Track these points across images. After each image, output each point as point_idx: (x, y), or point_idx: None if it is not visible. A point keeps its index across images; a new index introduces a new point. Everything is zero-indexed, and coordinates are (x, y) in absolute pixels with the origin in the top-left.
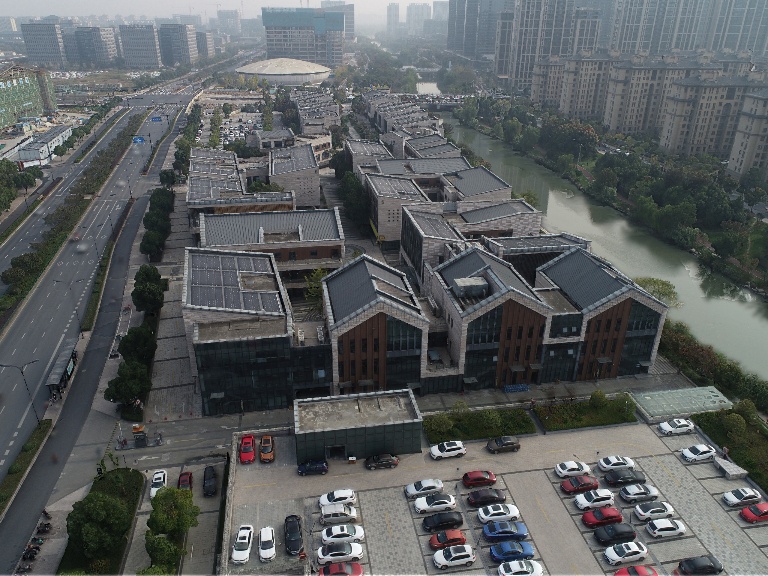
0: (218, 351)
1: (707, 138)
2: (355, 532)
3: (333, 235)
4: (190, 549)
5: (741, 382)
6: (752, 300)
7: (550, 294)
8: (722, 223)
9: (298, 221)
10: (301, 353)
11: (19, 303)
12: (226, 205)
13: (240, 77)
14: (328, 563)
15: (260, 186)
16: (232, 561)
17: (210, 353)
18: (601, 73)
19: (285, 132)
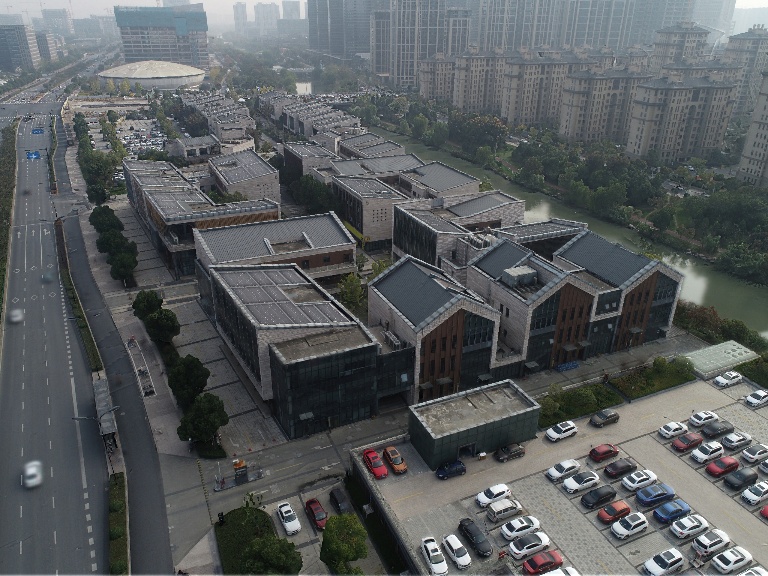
0: (308, 369)
1: (600, 125)
2: (532, 522)
3: (342, 239)
4: None
5: (746, 334)
6: (693, 265)
7: (580, 275)
8: (648, 200)
9: (299, 228)
10: (386, 360)
11: None
12: (208, 218)
13: (109, 82)
14: (524, 557)
15: (218, 196)
16: (434, 575)
17: (300, 372)
18: (489, 69)
19: (208, 138)
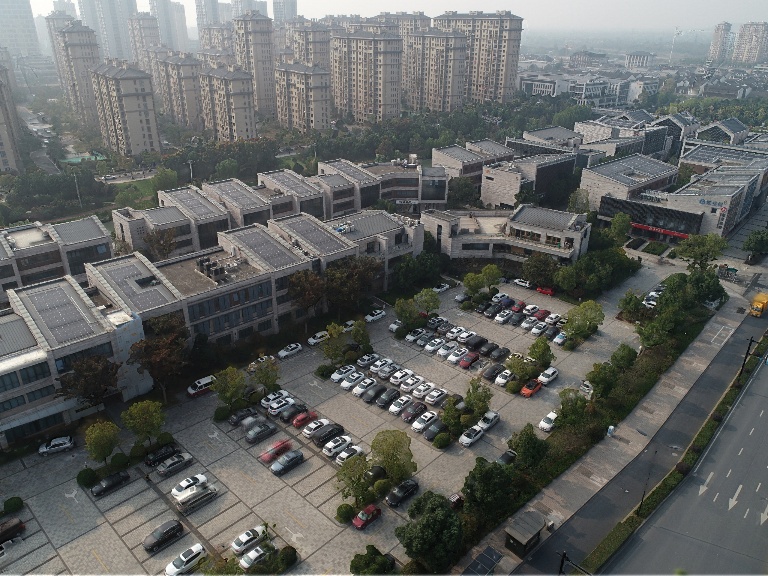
0: None
1: None
2: None
3: None
4: None
5: None
6: None
7: None
8: None
9: None
10: None
11: None
12: None
13: None
14: None
15: None
16: None
17: None
18: None
19: None
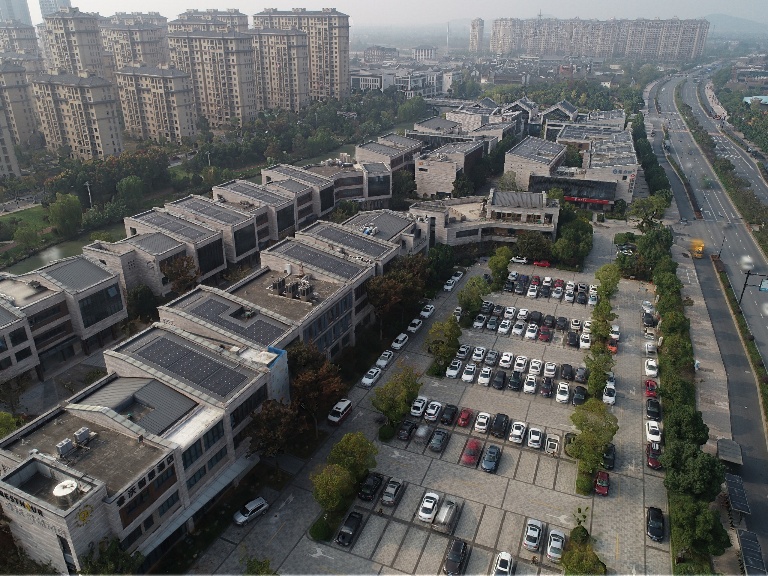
0: None
1: None
2: None
3: None
4: None
5: None
6: None
7: None
8: None
9: None
10: None
11: None
12: None
13: None
14: None
15: None
16: None
17: None
18: None
19: None
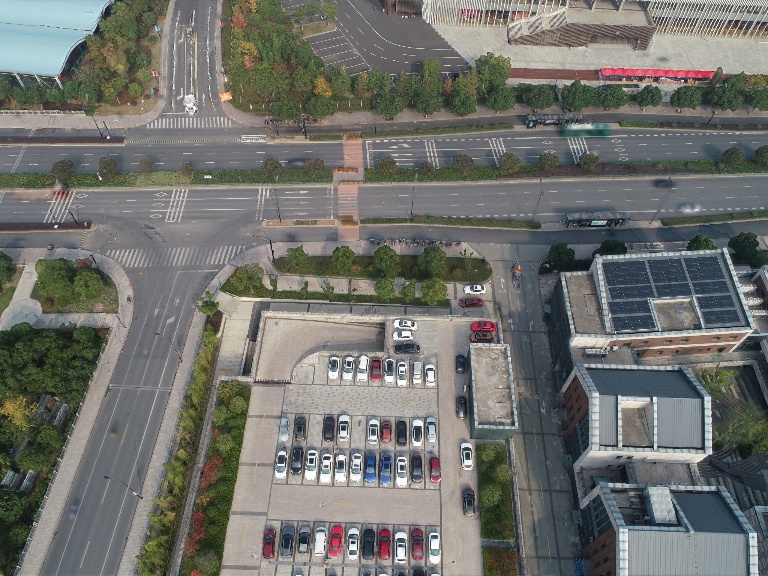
0: None
1: None
2: (401, 379)
3: None
4: (425, 310)
5: None
6: None
7: None
8: None
9: None
10: None
11: (699, 172)
12: None
13: None
14: None
15: None
16: None
17: None
18: None
19: None
